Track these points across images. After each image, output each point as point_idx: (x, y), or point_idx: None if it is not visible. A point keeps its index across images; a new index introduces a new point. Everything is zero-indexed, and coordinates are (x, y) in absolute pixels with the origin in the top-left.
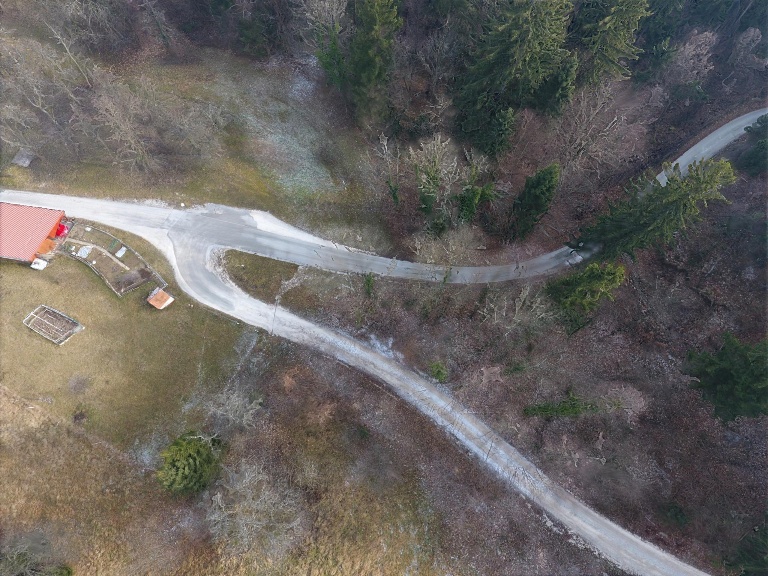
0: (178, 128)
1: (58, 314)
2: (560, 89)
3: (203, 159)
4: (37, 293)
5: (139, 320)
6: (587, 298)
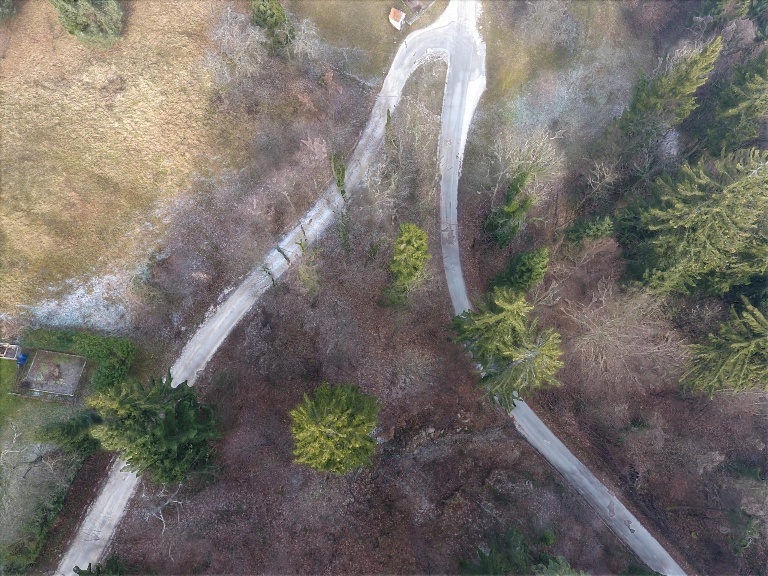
0: None
1: None
2: None
3: None
4: None
5: (379, 6)
6: None
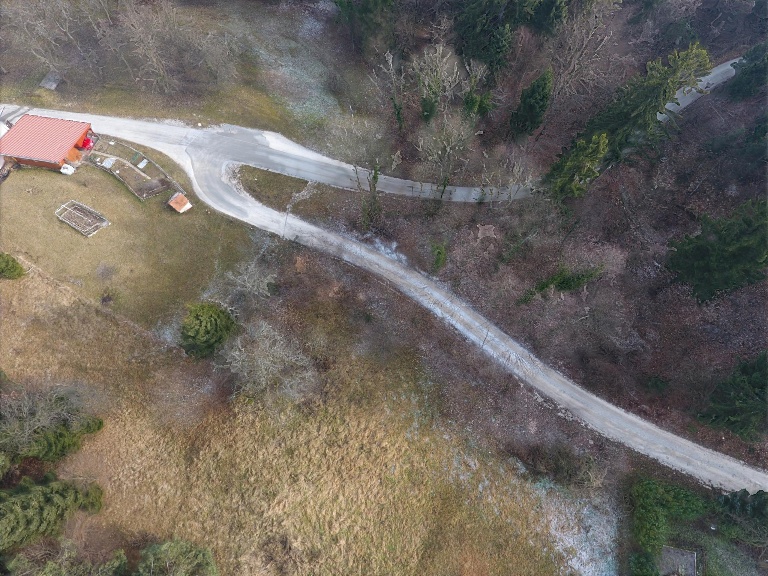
0: (196, 50)
1: (86, 210)
2: (554, 7)
3: (218, 86)
4: (66, 192)
5: (160, 220)
6: (575, 180)
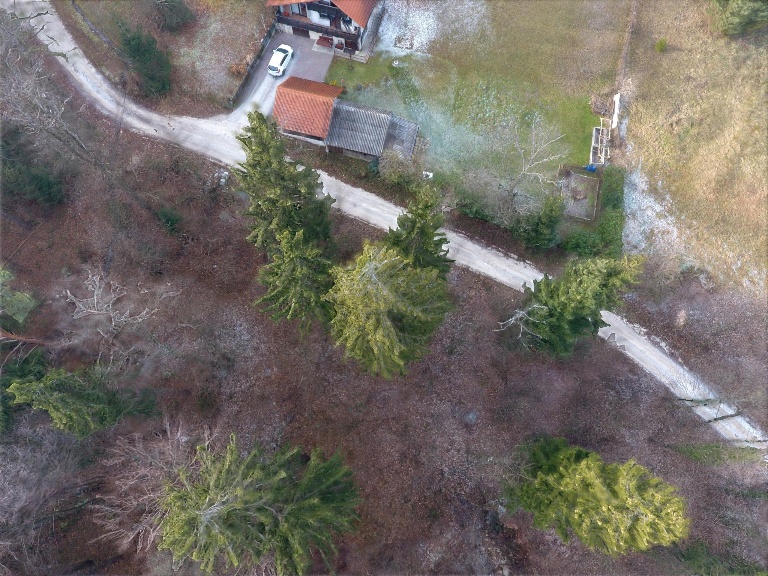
0: None
1: None
2: None
3: None
4: None
5: None
6: None
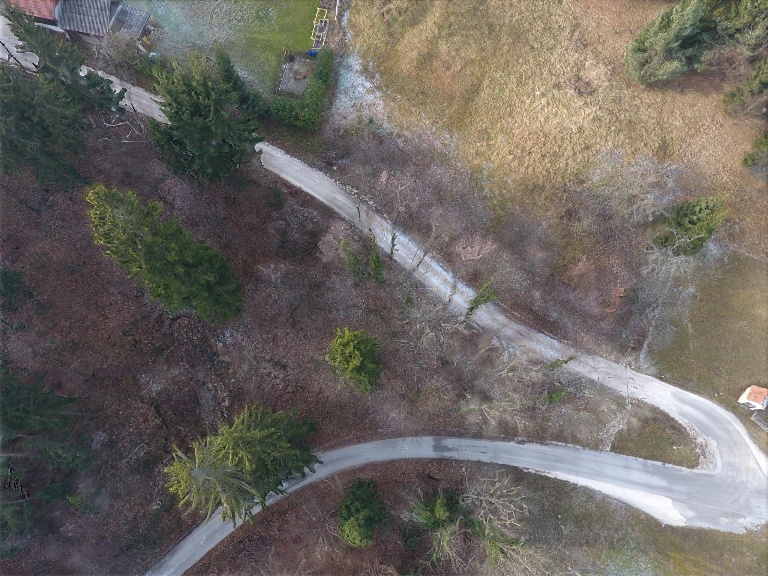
0: None
1: None
2: None
3: None
4: None
5: None
6: None
